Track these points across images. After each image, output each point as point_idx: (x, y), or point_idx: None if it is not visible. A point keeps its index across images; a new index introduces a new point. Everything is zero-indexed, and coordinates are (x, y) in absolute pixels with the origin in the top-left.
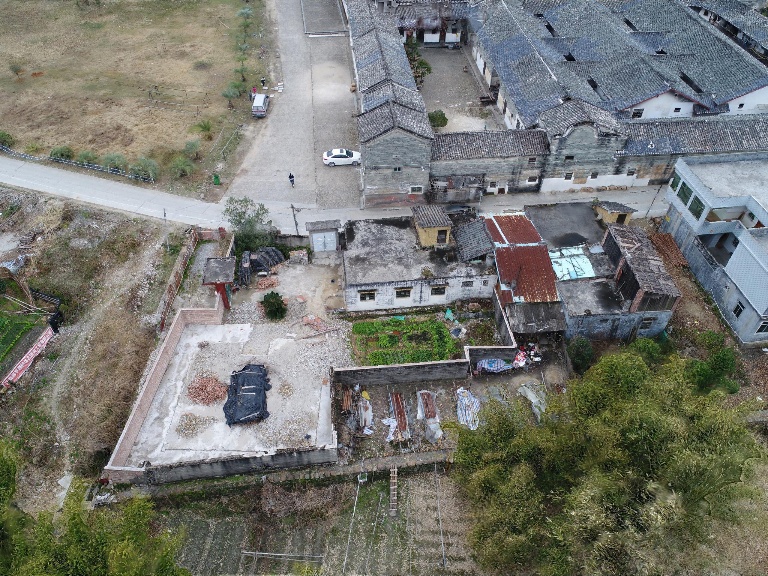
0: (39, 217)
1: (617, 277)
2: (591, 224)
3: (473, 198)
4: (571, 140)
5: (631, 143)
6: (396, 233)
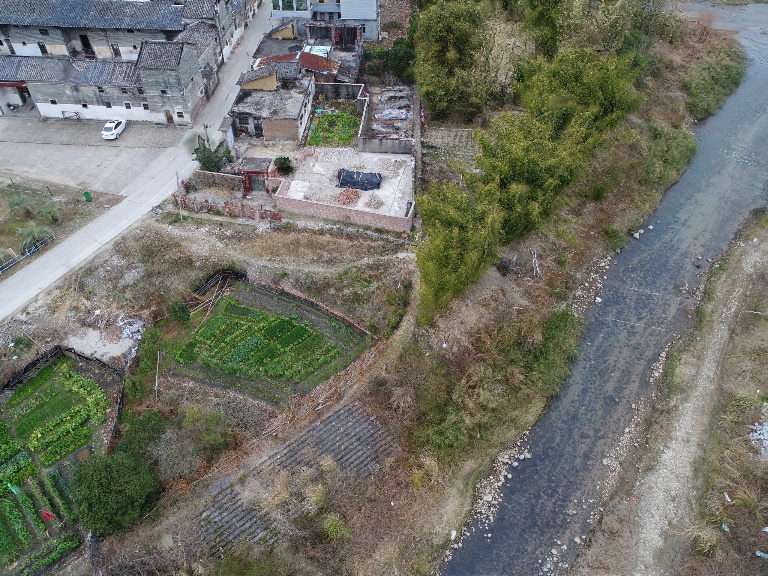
0: (55, 316)
1: (335, 41)
2: (284, 42)
3: (217, 82)
4: (220, 15)
5: None
6: (255, 98)
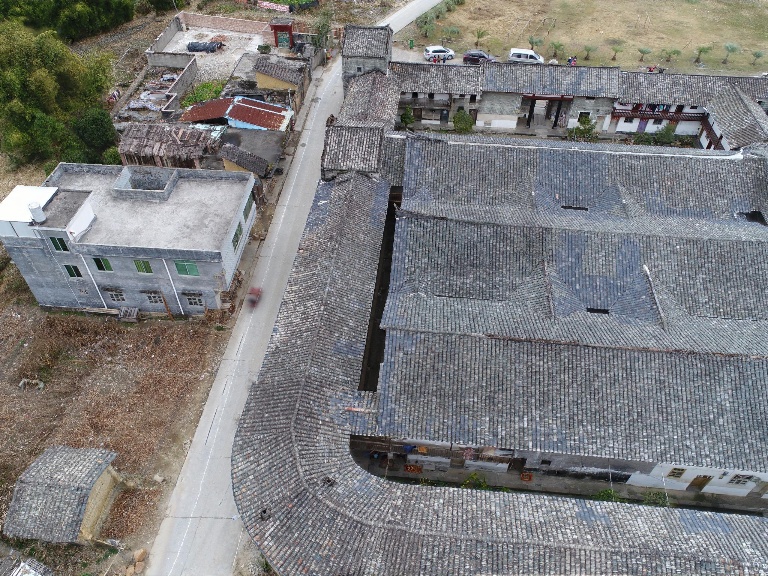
0: None
1: None
2: None
3: None
4: None
5: (329, 187)
6: None
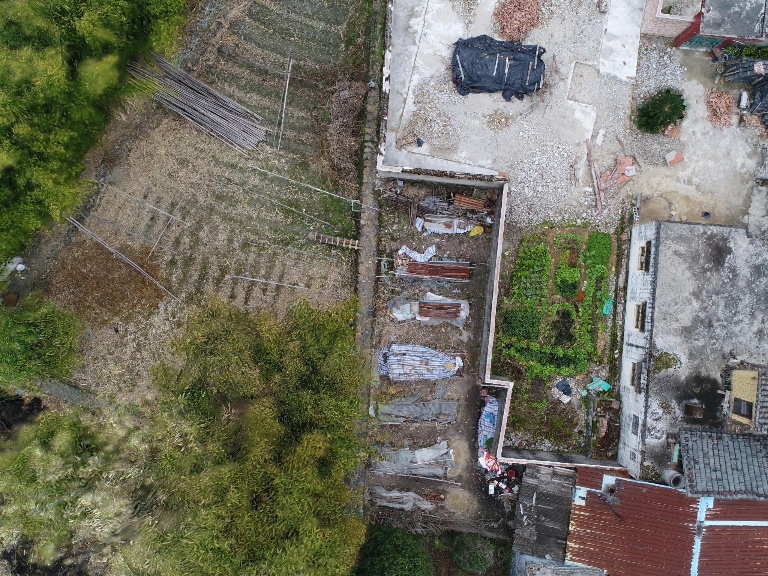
0: None
1: None
2: None
3: None
4: None
5: None
6: None
